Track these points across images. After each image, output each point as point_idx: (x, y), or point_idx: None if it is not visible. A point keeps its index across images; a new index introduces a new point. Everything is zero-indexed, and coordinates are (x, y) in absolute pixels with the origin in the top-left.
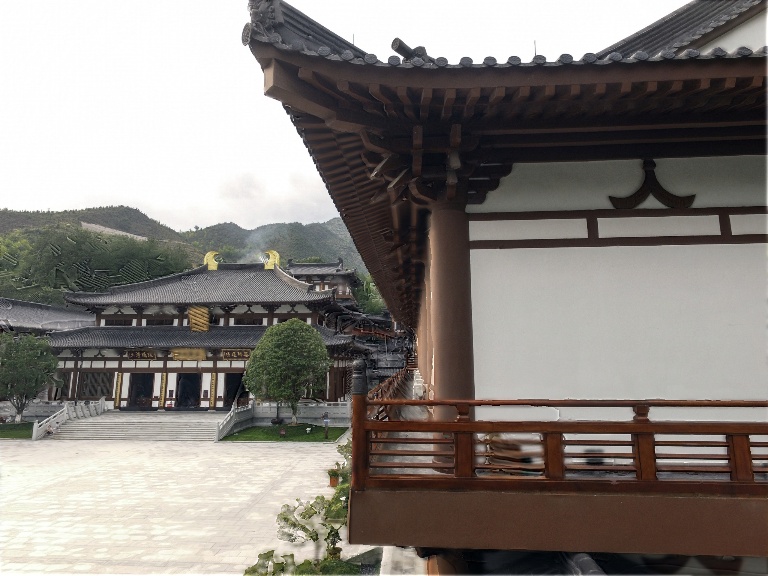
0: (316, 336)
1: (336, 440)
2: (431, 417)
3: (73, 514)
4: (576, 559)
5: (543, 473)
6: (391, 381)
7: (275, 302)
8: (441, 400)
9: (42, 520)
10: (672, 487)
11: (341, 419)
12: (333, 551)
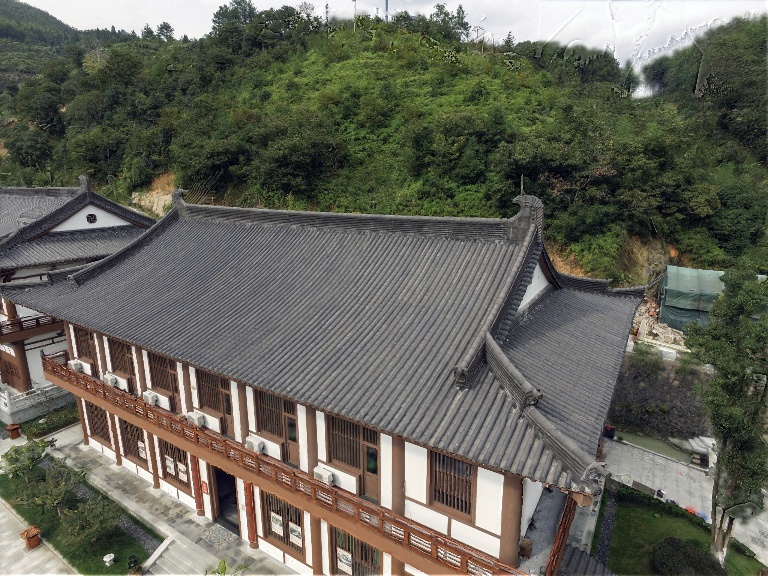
0: None
1: None
2: (401, 512)
3: None
4: (559, 570)
5: None
6: (336, 491)
7: None
8: (550, 557)
9: None
10: None
11: None
12: None
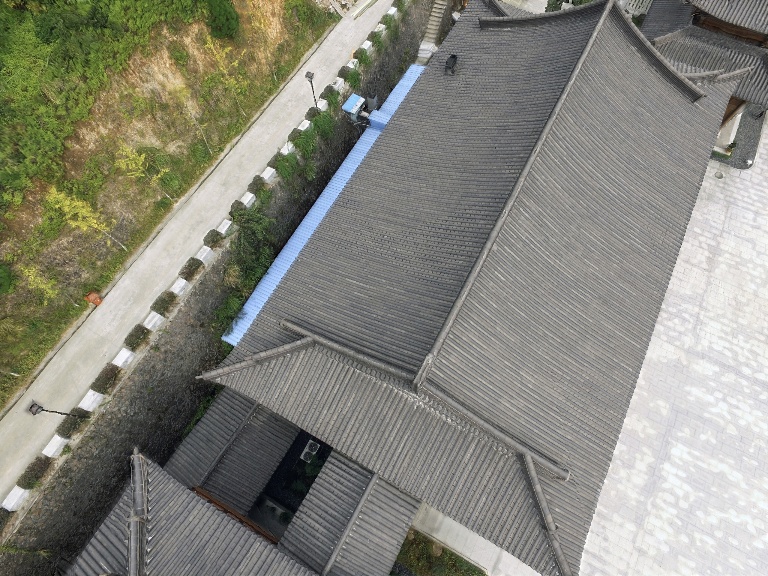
0: None
1: None
2: None
3: None
4: None
5: None
6: None
7: None
8: None
9: None
10: None
11: None
12: None
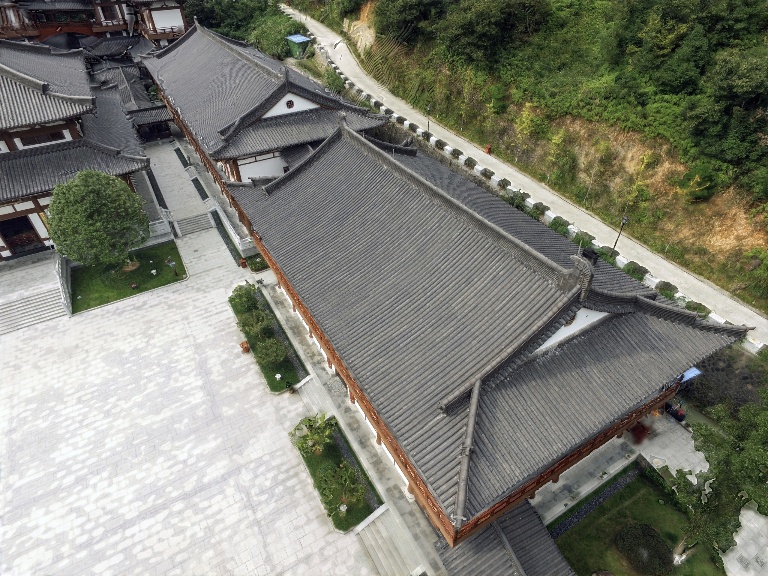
0: (121, 187)
1: (187, 275)
2: None
3: (93, 473)
4: None
5: (489, 515)
6: None
7: (13, 127)
8: None
9: (79, 491)
10: (511, 502)
11: (163, 235)
12: (310, 427)
